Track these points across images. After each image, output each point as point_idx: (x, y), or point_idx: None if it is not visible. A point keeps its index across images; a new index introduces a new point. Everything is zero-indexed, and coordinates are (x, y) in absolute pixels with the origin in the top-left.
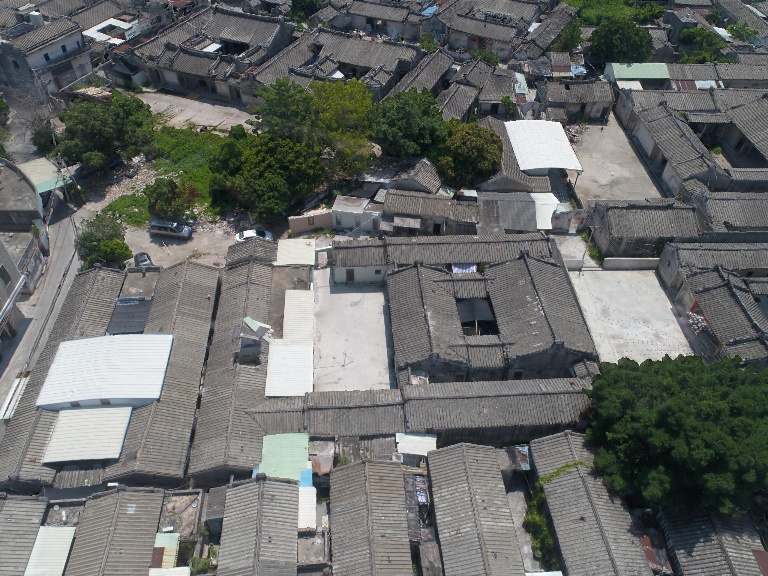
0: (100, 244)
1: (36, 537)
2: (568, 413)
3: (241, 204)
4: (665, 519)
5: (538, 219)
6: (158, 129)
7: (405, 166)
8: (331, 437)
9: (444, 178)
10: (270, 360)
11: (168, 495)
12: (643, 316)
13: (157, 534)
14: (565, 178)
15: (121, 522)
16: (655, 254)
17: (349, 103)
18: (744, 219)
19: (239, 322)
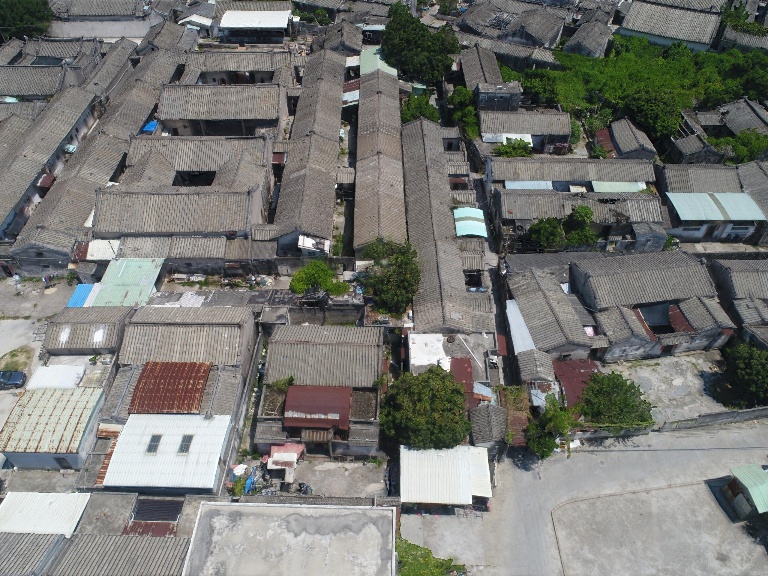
0: None
1: None
2: None
3: None
4: None
5: (184, 19)
6: None
7: None
8: None
9: None
10: None
11: None
12: None
13: None
14: None
15: None
16: None
17: None
18: None
19: None
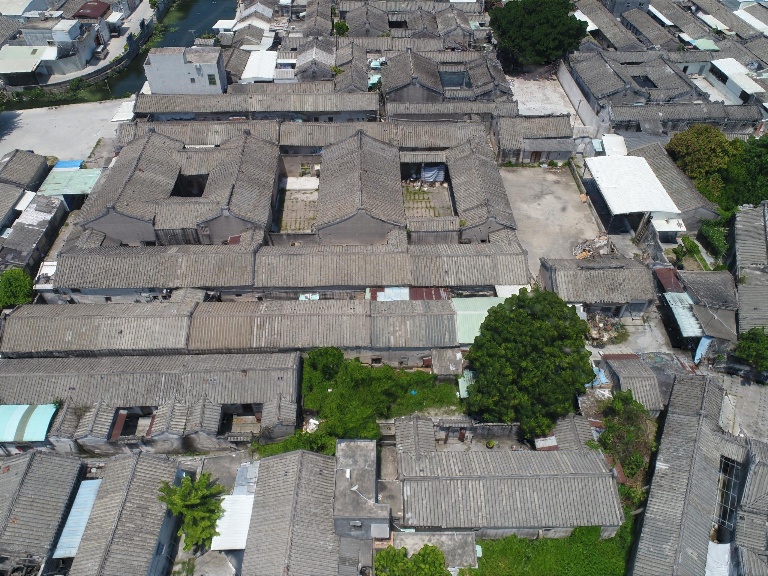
0: None
1: None
2: None
3: None
4: None
5: None
6: None
7: None
8: None
9: None
10: None
11: None
12: (530, 111)
13: None
14: None
15: None
16: None
17: None
18: None
19: None
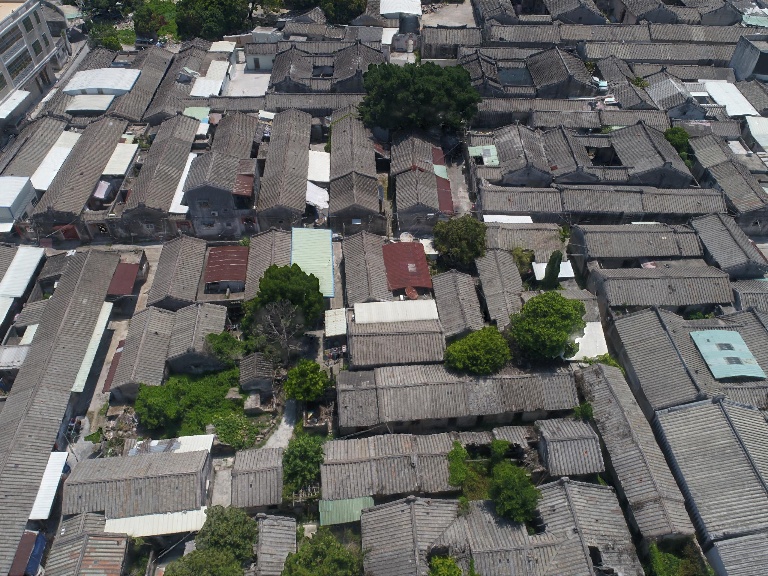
0: (103, 39)
1: (61, 133)
2: (358, 103)
3: (196, 35)
4: (392, 137)
5: (383, 38)
6: (148, 2)
7: (305, 12)
8: (223, 110)
9: (329, 19)
10: (196, 84)
11: (131, 125)
12: None
13: (123, 134)
14: (418, 28)
15: (105, 126)
16: (454, 57)
17: None
18: (514, 37)
19: (181, 69)
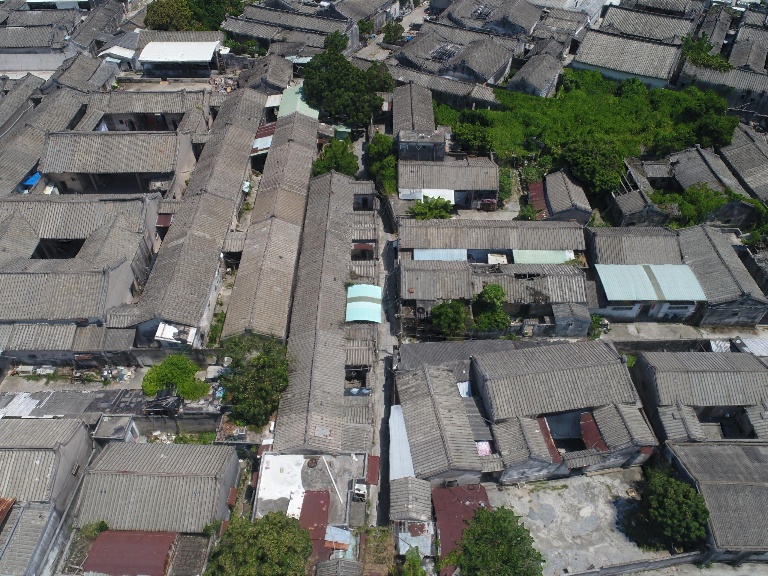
0: None
1: None
2: None
3: None
4: None
5: None
6: None
7: None
8: None
9: None
10: None
11: None
12: None
13: None
14: None
15: None
16: None
17: None
18: None
19: None
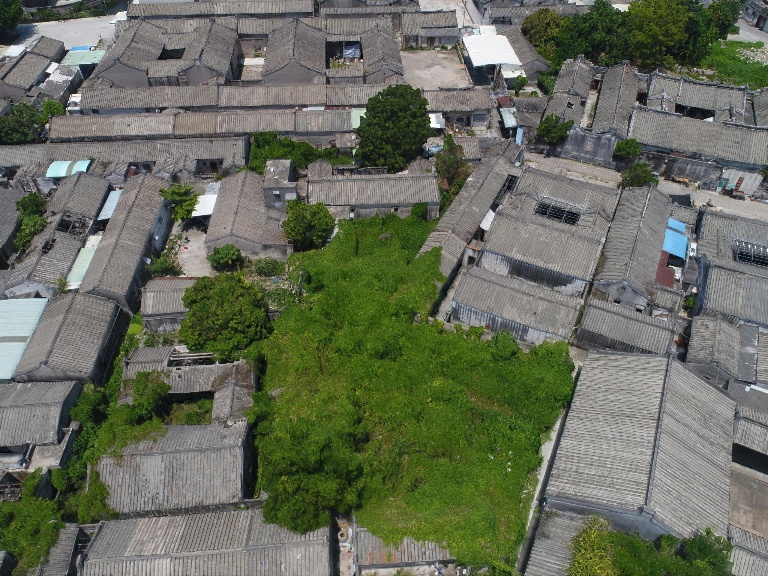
0: None
1: None
2: None
3: None
4: None
5: None
6: None
7: None
8: None
9: None
10: None
11: None
12: None
13: None
14: None
15: None
16: None
17: (643, 6)
18: None
19: None
